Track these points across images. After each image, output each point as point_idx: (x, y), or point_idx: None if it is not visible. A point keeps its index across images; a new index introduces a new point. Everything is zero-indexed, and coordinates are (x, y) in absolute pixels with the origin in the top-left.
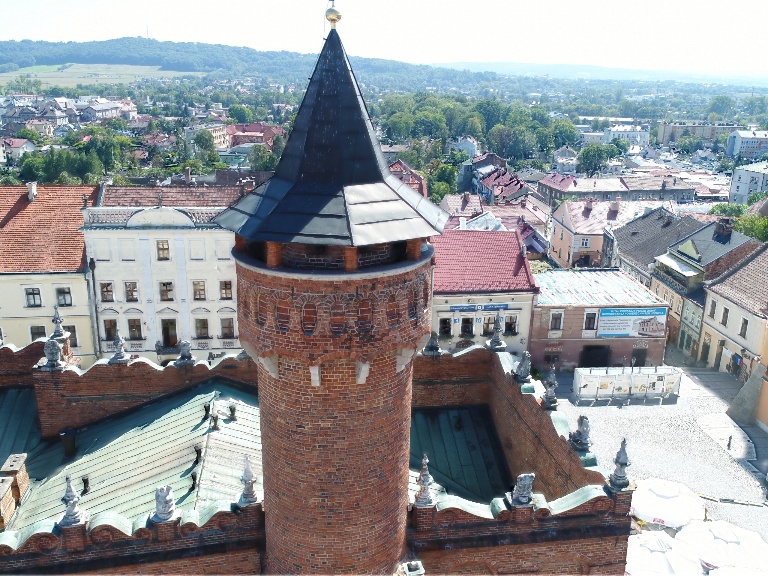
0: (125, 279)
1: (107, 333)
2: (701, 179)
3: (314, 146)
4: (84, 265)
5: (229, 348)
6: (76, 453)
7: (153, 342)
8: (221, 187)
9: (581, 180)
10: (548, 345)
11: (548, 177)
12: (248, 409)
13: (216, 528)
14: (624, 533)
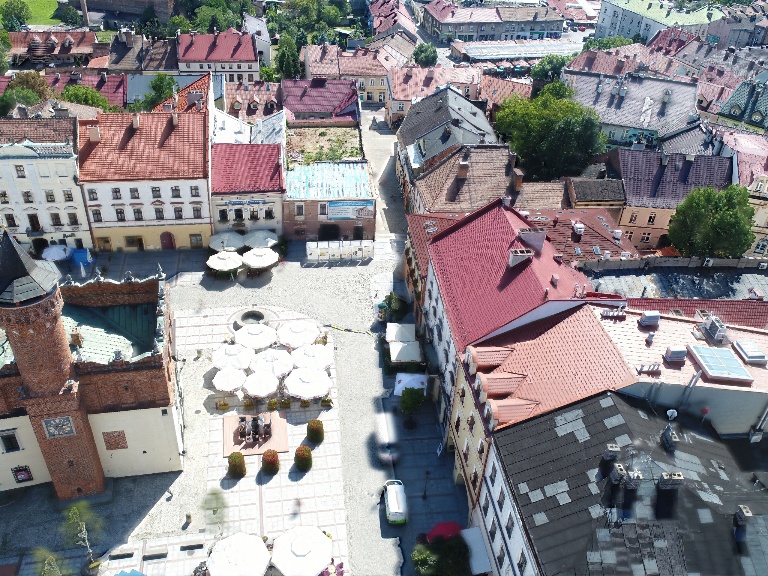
0: None
1: None
2: (584, 2)
3: (4, 267)
4: None
5: (76, 231)
6: None
7: (24, 228)
8: (60, 119)
9: (459, 10)
10: (296, 224)
11: (433, 3)
12: None
13: (7, 369)
14: (160, 368)
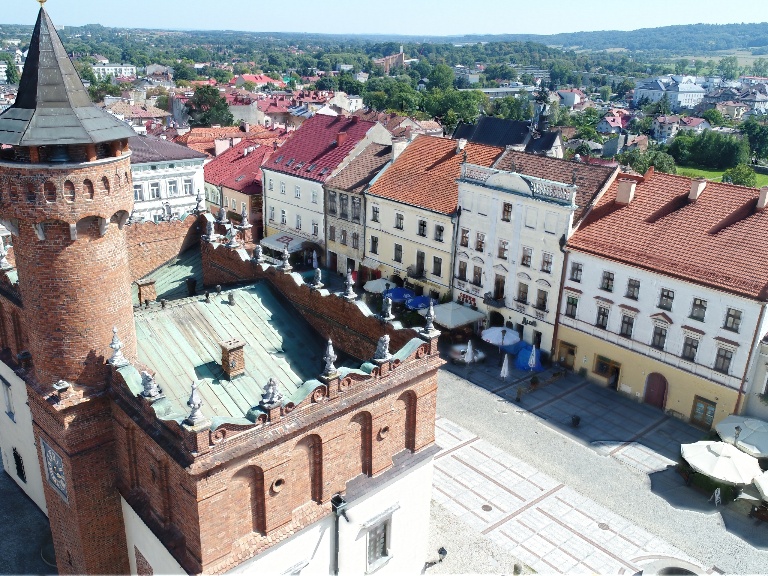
0: (478, 230)
1: (461, 272)
2: None
3: None
4: (455, 211)
5: (540, 319)
6: (191, 295)
7: (487, 291)
8: (596, 166)
9: None
10: None
11: None
12: (256, 305)
13: None
14: (183, 465)
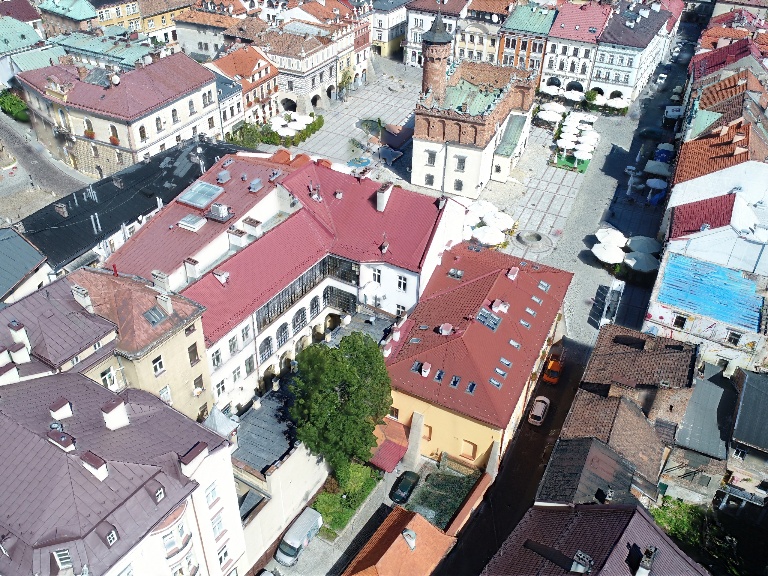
0: None
1: None
2: None
3: None
4: None
5: None
6: None
7: None
8: None
9: None
10: None
11: None
12: (492, 99)
13: None
14: None
